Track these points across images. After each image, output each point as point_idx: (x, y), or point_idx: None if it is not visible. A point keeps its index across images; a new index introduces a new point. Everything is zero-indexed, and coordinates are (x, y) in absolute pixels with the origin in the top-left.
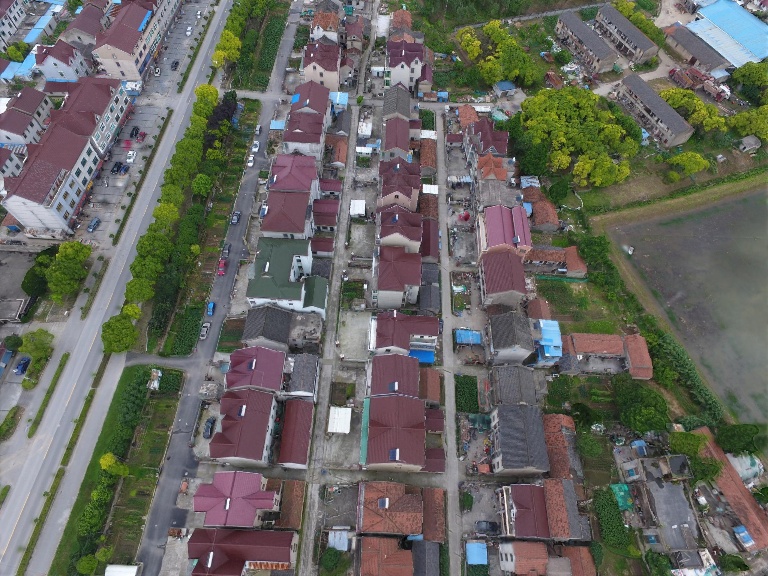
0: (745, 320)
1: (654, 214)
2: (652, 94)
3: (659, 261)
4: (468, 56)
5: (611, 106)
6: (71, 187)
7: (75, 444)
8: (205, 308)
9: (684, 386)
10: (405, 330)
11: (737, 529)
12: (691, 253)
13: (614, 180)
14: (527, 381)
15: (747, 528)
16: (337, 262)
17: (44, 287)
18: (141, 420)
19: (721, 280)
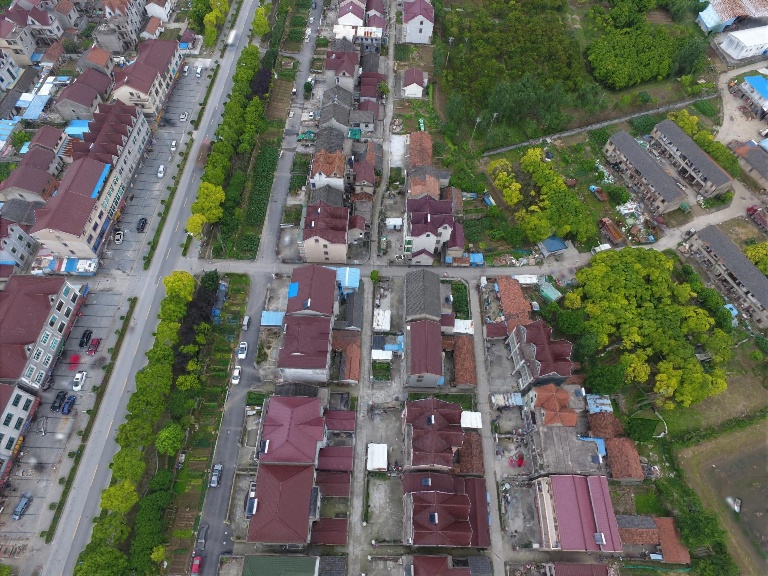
0: None
1: (759, 441)
2: (739, 258)
3: None
4: (504, 198)
5: (687, 272)
6: None
7: None
8: None
9: None
10: None
11: None
12: None
13: (706, 396)
14: None
15: None
16: (352, 551)
17: None
18: None
19: None
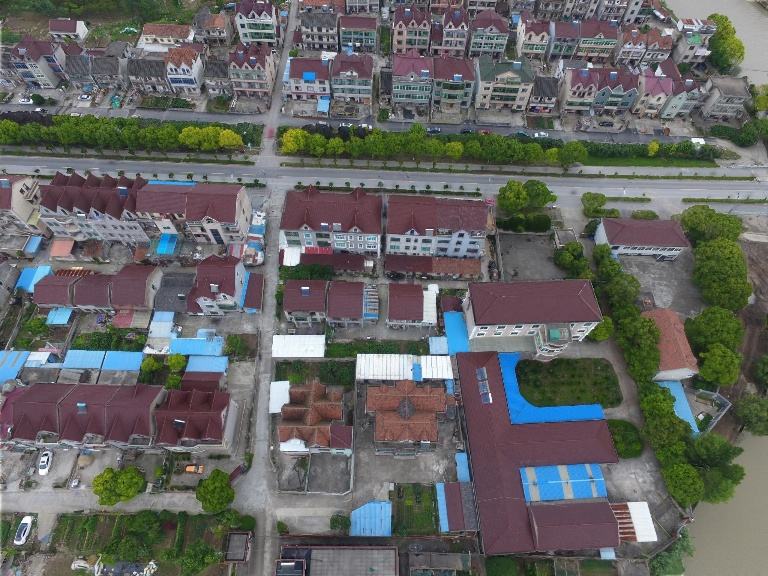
0: None
1: None
2: None
3: None
4: None
5: None
6: None
7: None
8: None
9: None
10: None
11: None
12: None
13: None
14: None
15: None
16: None
17: None
18: None
19: None
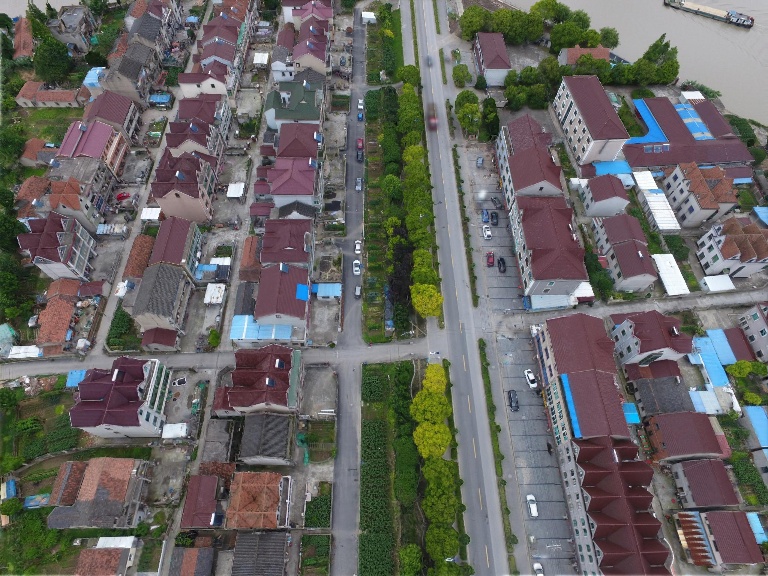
0: None
1: None
2: None
3: None
4: None
5: None
6: None
7: None
8: None
9: None
10: None
11: None
12: None
13: None
14: None
15: None
16: None
17: None
18: None
19: None
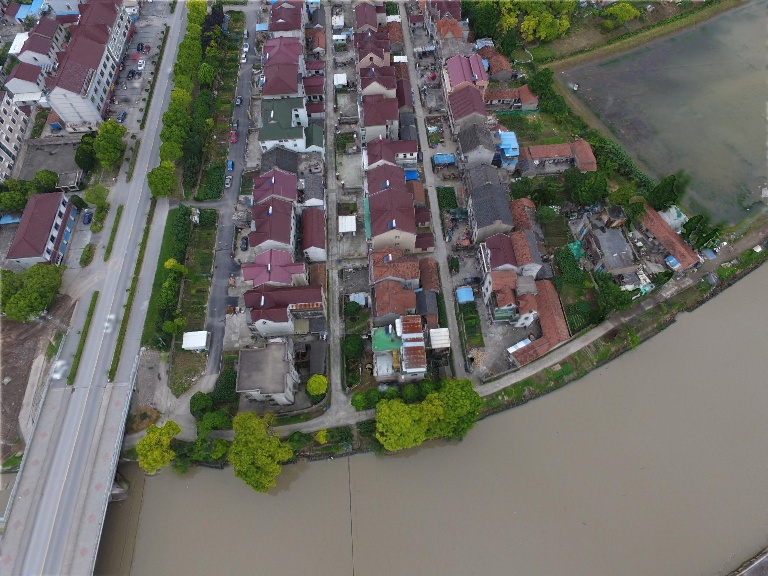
0: (674, 125)
1: (594, 58)
2: None
3: (600, 92)
4: None
5: None
6: (99, 84)
7: (142, 261)
8: (225, 167)
9: (624, 175)
10: (390, 150)
11: (667, 259)
12: (627, 83)
13: (557, 33)
14: (492, 174)
15: (675, 256)
16: (329, 122)
17: (92, 162)
18: (190, 243)
19: (653, 100)
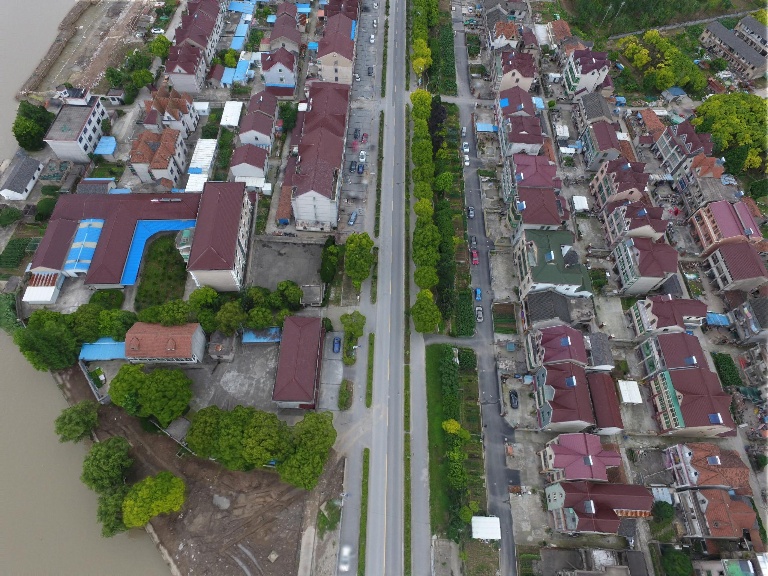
0: None
1: None
2: None
3: None
4: (632, 63)
5: None
6: None
7: (409, 413)
8: (471, 294)
9: None
10: (678, 312)
11: None
12: None
13: None
14: None
15: None
16: None
17: (334, 274)
18: None
19: None
